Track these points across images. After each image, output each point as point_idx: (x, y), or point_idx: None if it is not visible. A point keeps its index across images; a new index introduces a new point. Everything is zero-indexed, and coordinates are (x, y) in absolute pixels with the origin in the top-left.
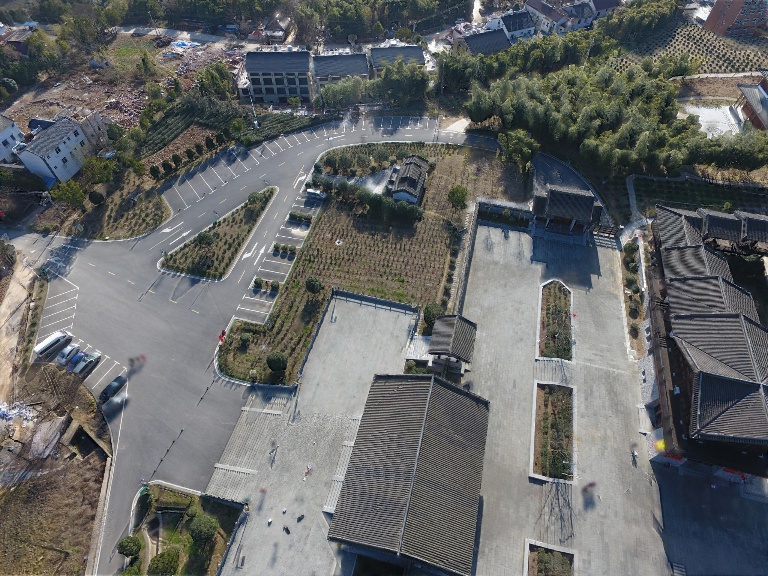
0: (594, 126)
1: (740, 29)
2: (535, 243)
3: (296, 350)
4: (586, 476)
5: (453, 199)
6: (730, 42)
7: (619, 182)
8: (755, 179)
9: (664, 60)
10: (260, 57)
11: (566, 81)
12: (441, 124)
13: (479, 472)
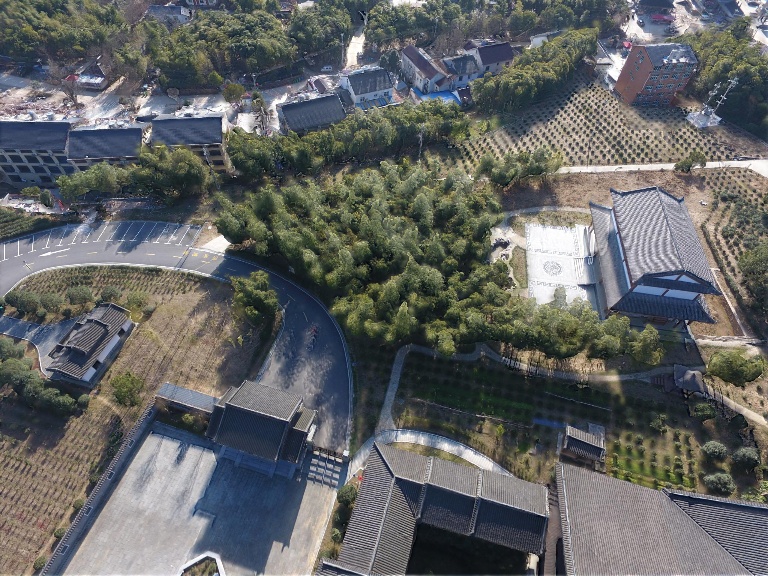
0: (362, 272)
1: (654, 95)
2: (217, 472)
3: None
4: None
5: (113, 394)
6: (632, 116)
7: (386, 357)
8: (574, 364)
9: (508, 158)
10: (4, 128)
11: (352, 194)
12: (200, 237)
13: None
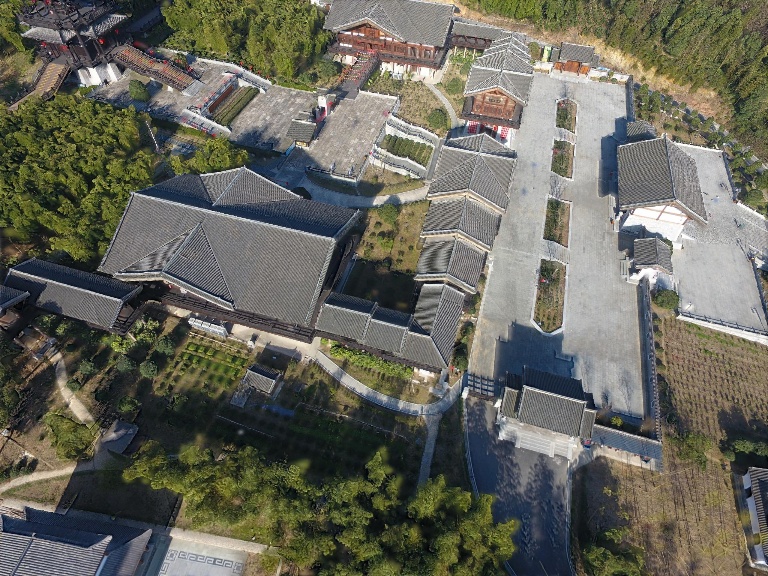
0: None
1: None
2: None
3: (767, 296)
4: (540, 196)
5: None
6: None
7: None
8: None
9: None
10: None
11: None
12: None
13: (621, 178)
